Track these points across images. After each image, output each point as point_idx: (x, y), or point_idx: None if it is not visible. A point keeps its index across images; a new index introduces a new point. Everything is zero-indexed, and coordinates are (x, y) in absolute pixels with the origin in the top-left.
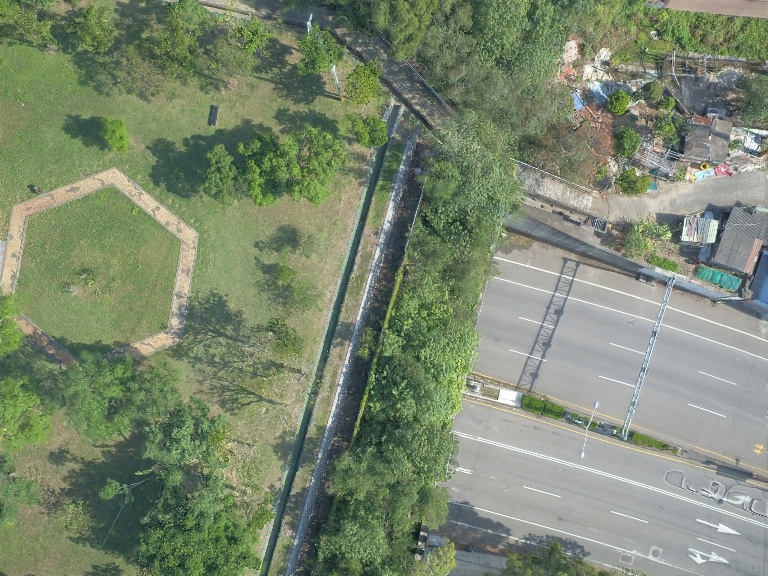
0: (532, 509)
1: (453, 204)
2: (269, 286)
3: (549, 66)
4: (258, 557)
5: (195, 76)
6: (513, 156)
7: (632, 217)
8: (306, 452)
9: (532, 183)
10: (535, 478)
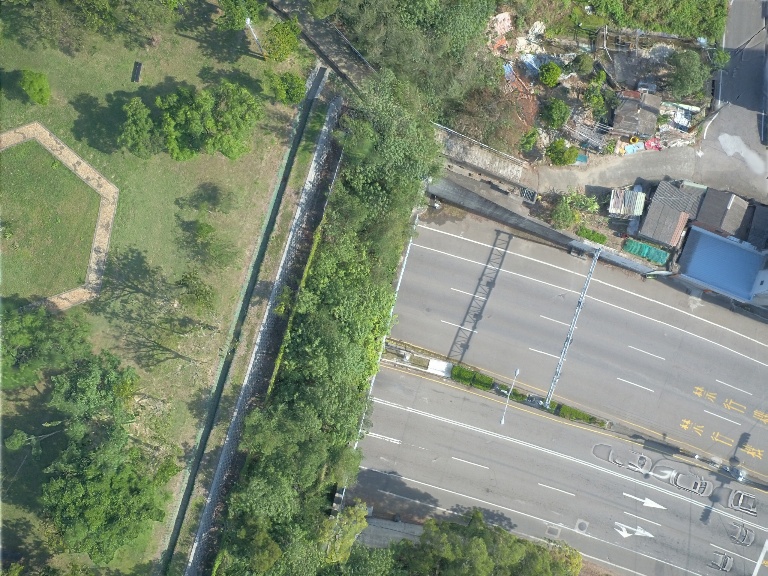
0: (460, 480)
1: (372, 164)
2: (188, 243)
3: (475, 33)
4: (169, 514)
5: (120, 32)
6: (432, 118)
7: (562, 189)
8: (221, 410)
9: (459, 150)
10: (464, 449)
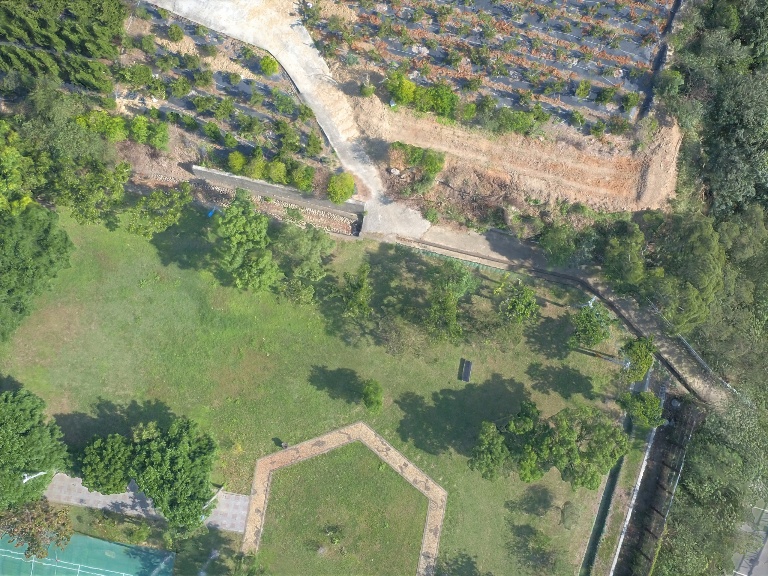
0: None
1: (719, 478)
2: (519, 548)
3: None
4: None
5: None
6: None
7: None
8: None
9: None
10: None
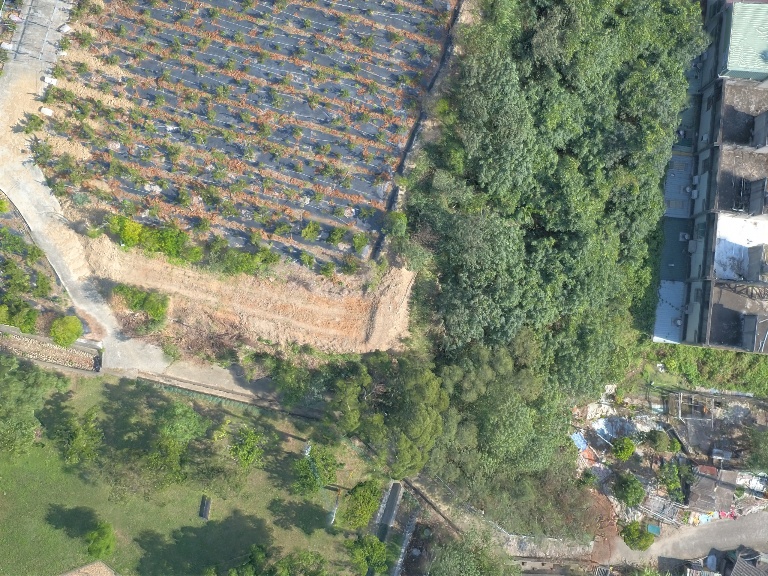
0: None
1: None
2: None
3: None
4: None
5: (187, 464)
6: (516, 570)
7: (634, 560)
8: None
9: (533, 547)
10: None
